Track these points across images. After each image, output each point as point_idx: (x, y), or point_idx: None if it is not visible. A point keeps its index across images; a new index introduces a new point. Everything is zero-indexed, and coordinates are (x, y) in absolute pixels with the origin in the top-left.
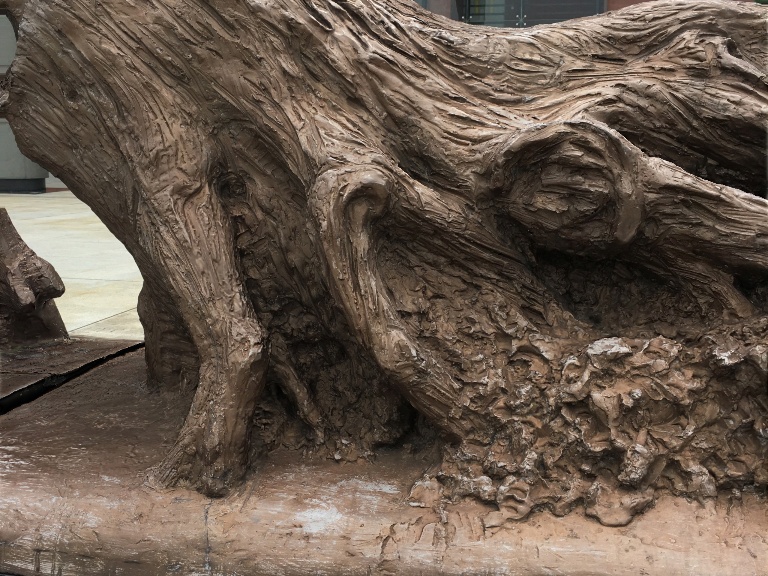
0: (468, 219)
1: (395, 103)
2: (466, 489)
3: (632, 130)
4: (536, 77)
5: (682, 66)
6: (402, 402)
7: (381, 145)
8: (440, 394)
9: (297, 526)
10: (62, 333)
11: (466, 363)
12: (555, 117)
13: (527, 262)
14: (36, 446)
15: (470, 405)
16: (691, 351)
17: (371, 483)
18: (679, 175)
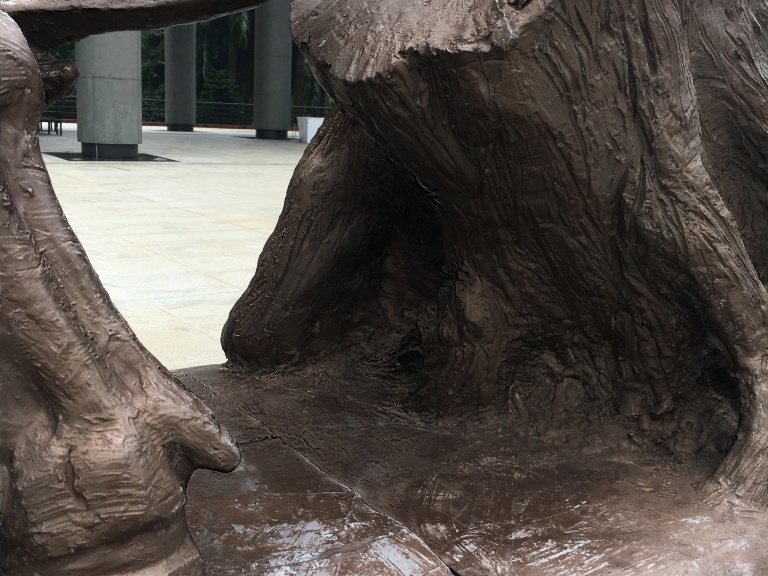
0: None
1: None
2: None
3: None
4: None
5: None
6: None
7: None
8: None
9: None
10: None
11: None
12: None
13: None
14: (536, 520)
15: None
16: None
17: None
18: None
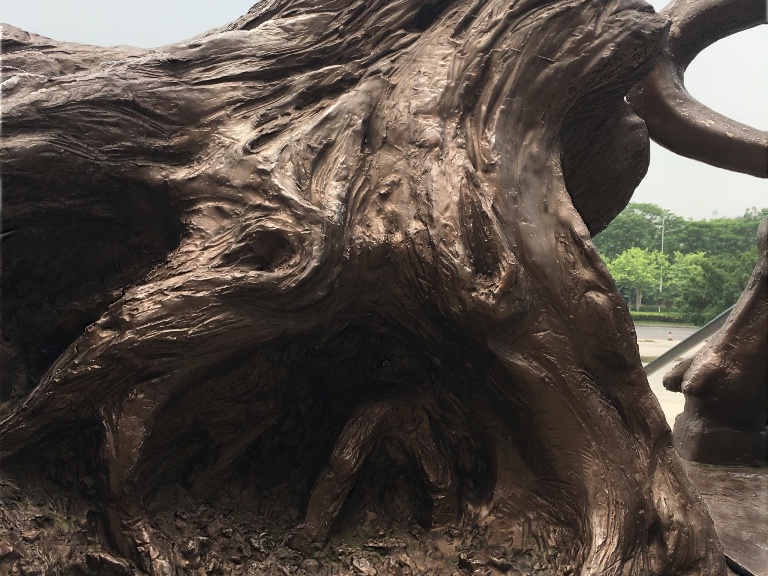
0: None
1: None
2: None
3: None
4: None
5: None
6: None
7: None
8: None
9: None
10: None
11: None
12: None
13: None
14: None
15: None
16: None
17: None
18: None
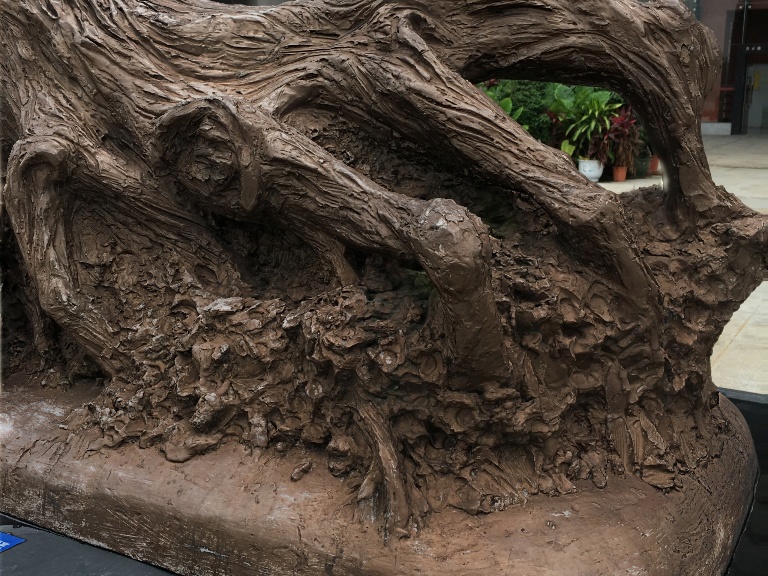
0: (145, 185)
1: (102, 81)
2: (96, 418)
3: (332, 103)
4: (256, 53)
5: (374, 40)
6: None
7: (88, 118)
8: (93, 336)
9: None
10: None
11: (129, 311)
12: (260, 91)
13: (208, 225)
14: None
15: (120, 347)
16: (286, 314)
17: (51, 406)
18: (288, 149)
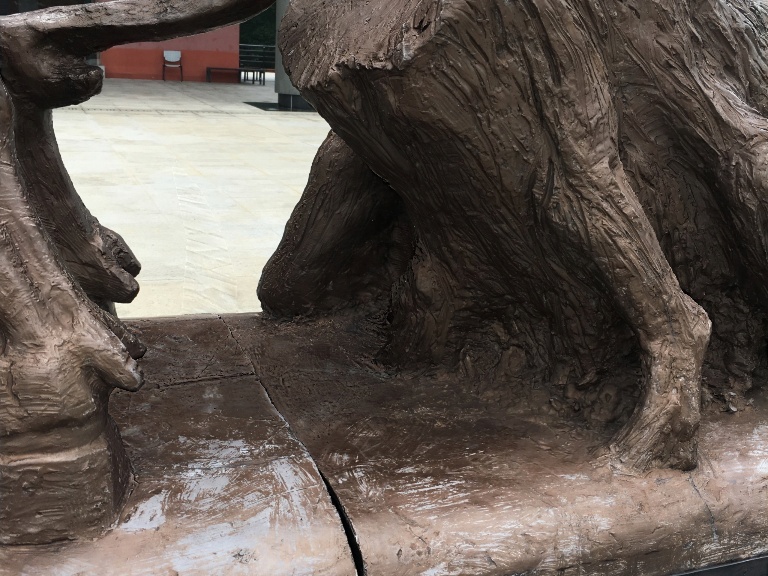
0: None
1: (755, 72)
2: None
3: None
4: None
5: None
6: (758, 350)
7: None
8: None
9: (766, 478)
10: None
11: None
12: None
13: None
14: (429, 461)
15: None
16: None
17: None
18: None
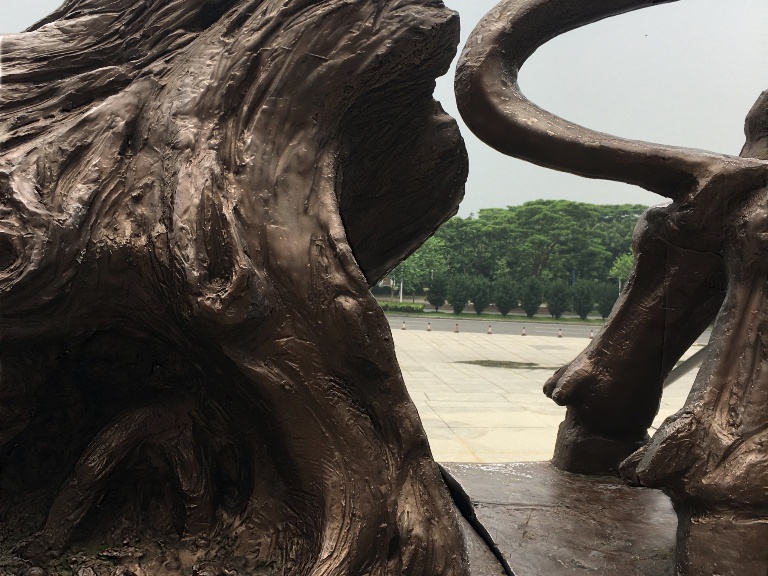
0: None
1: None
2: None
3: None
4: None
5: None
6: None
7: None
8: None
9: None
10: (678, 574)
11: None
12: None
13: None
14: None
15: None
16: None
17: None
18: None
